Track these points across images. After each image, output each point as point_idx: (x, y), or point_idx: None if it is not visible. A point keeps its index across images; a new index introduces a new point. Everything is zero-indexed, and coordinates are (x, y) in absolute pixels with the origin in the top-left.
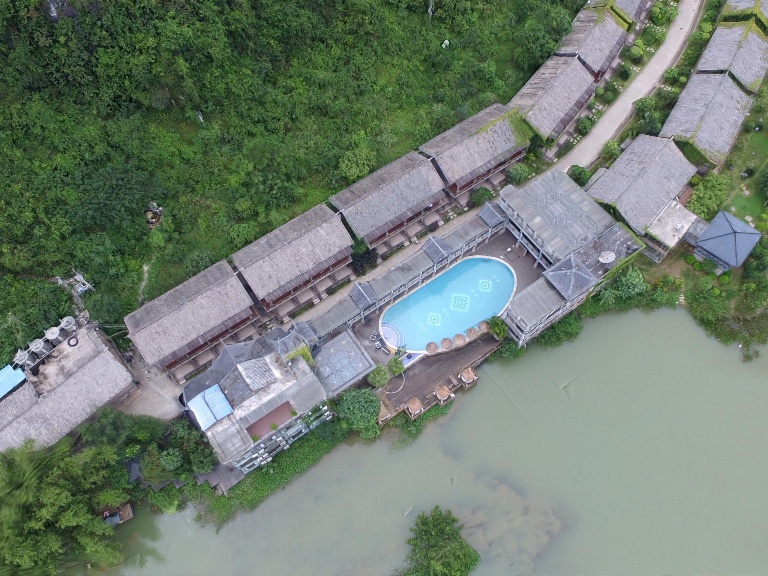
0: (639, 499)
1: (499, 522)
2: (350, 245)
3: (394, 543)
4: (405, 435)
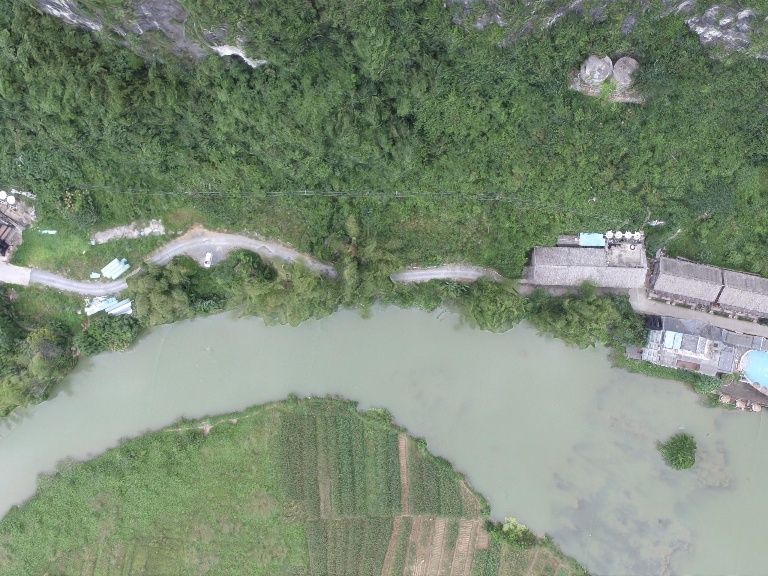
0: (763, 506)
1: (709, 463)
2: None
3: (667, 433)
4: (708, 402)
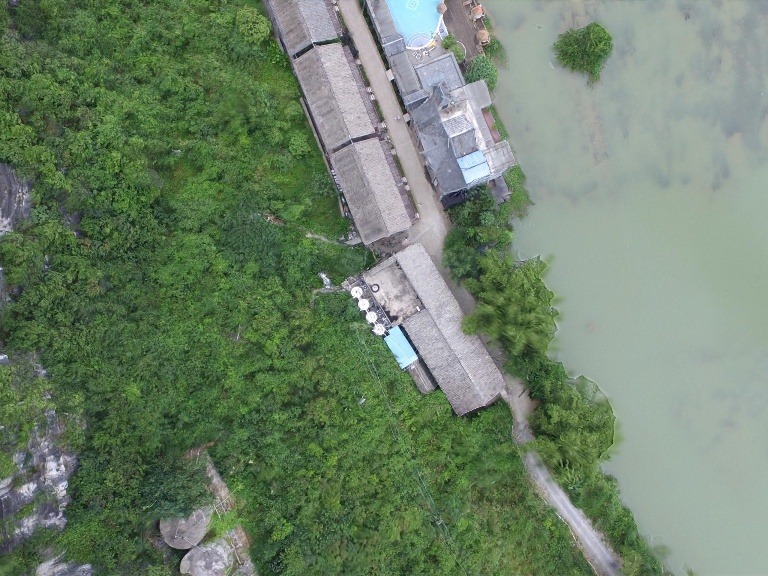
0: None
1: (574, 3)
2: (342, 47)
3: (571, 81)
4: (498, 54)
